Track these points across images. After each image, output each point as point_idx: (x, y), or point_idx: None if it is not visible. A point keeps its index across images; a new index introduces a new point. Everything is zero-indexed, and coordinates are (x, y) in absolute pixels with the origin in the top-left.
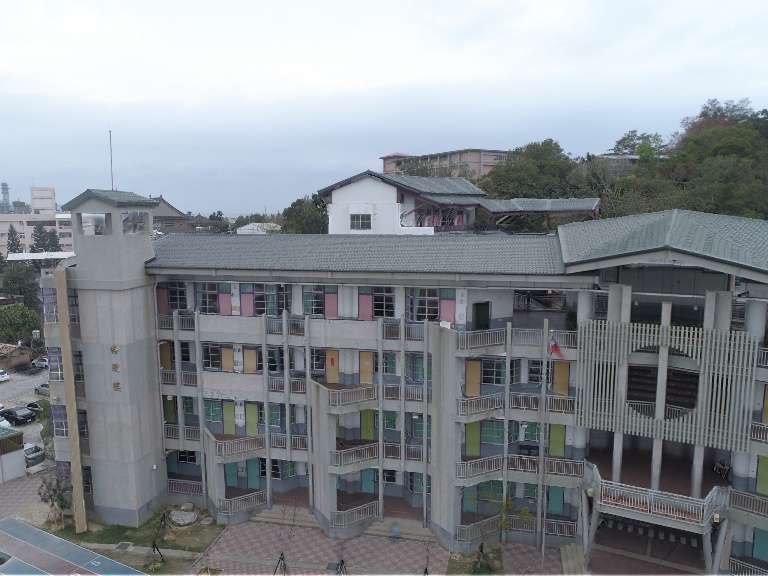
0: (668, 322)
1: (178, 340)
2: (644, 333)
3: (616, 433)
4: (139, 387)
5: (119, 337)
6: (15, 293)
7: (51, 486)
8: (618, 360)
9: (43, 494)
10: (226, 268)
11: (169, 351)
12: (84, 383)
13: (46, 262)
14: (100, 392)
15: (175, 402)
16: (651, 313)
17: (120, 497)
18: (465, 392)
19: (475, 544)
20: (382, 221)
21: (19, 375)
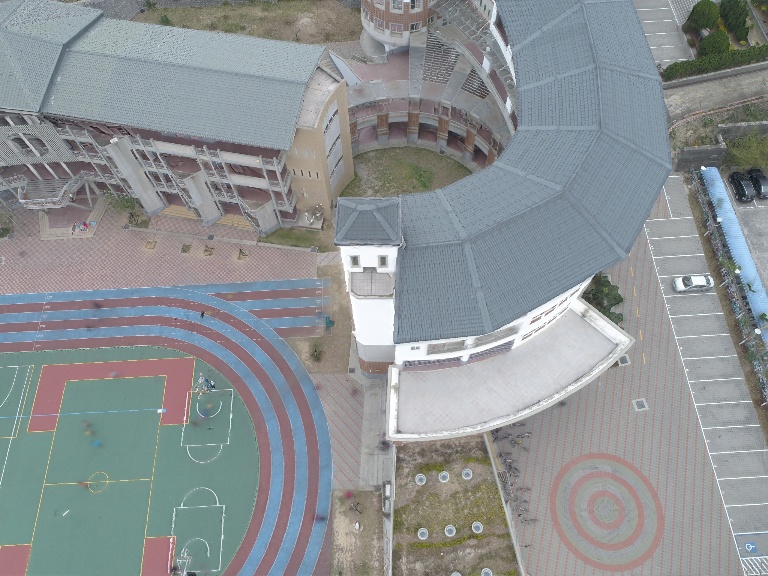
0: (13, 124)
1: None
2: (6, 129)
3: (26, 164)
4: None
5: None
6: None
7: None
8: (4, 140)
9: None
10: None
11: None
12: None
13: None
14: None
15: None
16: (3, 121)
17: None
18: None
19: None
20: None
21: None
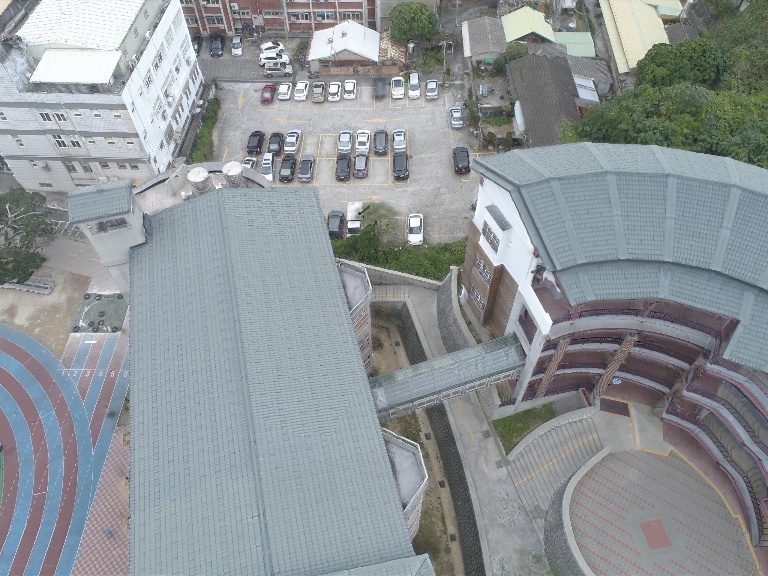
0: None
1: None
2: None
3: None
4: None
5: None
6: None
7: None
8: None
9: None
10: None
11: None
12: None
13: None
14: None
15: None
16: None
17: None
18: None
19: None
20: (513, 256)
21: (370, 93)
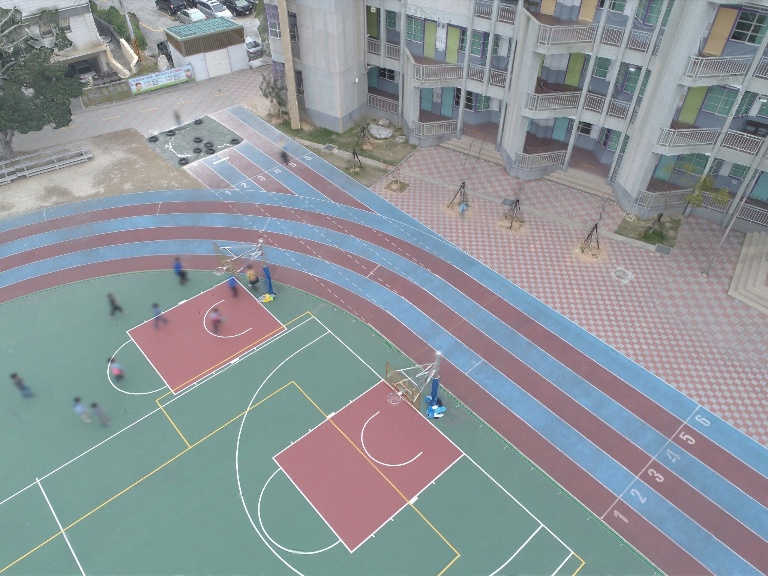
0: None
1: None
2: None
3: None
4: None
5: None
6: None
7: (270, 84)
8: None
9: (264, 90)
10: None
11: None
12: None
13: None
14: None
15: (378, 15)
16: None
17: (327, 104)
18: (703, 47)
19: (655, 211)
20: None
21: None
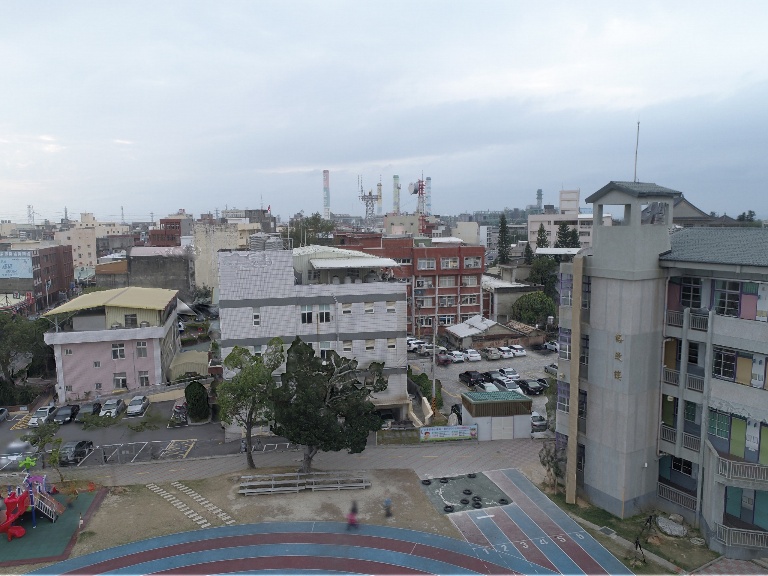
0: None
1: (686, 339)
2: None
3: None
4: (639, 380)
5: (625, 327)
6: (538, 282)
7: (550, 453)
8: None
9: (543, 457)
10: (755, 265)
11: (675, 349)
12: (588, 366)
13: (565, 257)
14: (601, 377)
15: (676, 404)
16: None
17: (609, 483)
18: None
19: None
20: None
21: (534, 353)
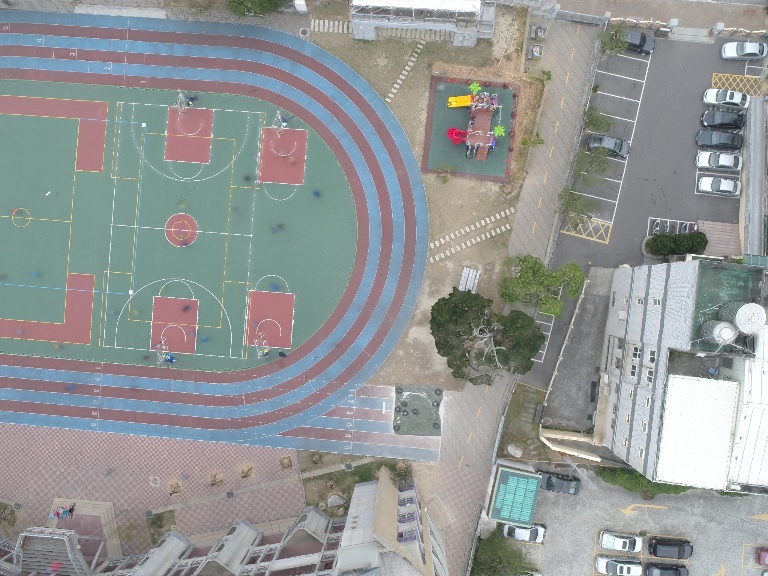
0: None
1: None
2: None
3: None
4: None
5: None
6: None
7: None
8: None
9: None
10: None
11: None
12: None
13: None
14: None
15: None
16: None
17: None
18: None
19: None
20: None
21: None
